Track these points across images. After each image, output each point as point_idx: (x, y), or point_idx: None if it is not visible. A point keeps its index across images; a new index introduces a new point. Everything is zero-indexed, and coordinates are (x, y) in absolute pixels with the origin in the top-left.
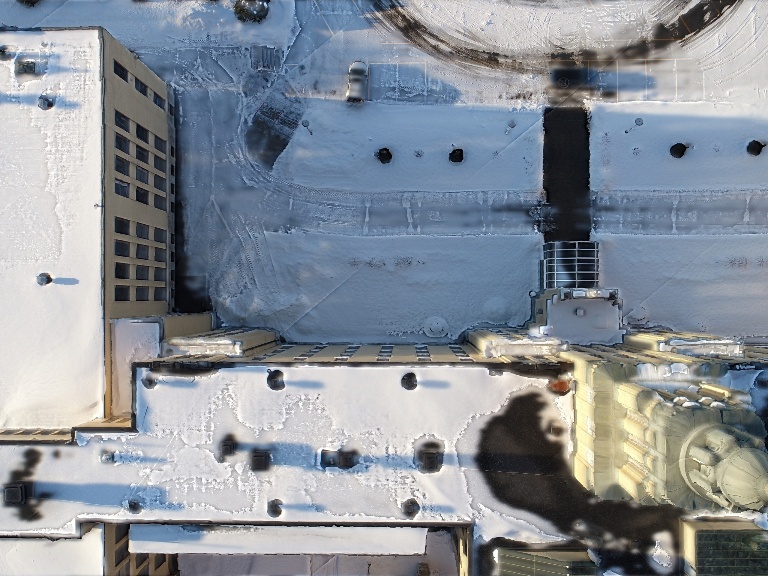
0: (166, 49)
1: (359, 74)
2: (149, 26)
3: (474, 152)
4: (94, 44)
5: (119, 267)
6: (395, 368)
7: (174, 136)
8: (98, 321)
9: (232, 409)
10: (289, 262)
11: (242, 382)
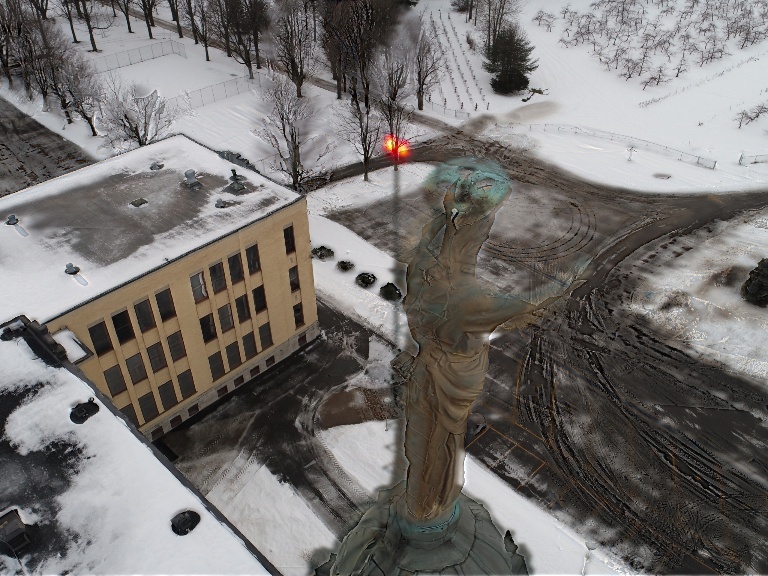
0: (344, 313)
1: (472, 420)
2: (349, 296)
3: (529, 562)
4: (290, 199)
5: (125, 319)
6: (191, 494)
7: (284, 357)
8: (56, 312)
9: (19, 403)
10: (252, 503)
11: (61, 390)
